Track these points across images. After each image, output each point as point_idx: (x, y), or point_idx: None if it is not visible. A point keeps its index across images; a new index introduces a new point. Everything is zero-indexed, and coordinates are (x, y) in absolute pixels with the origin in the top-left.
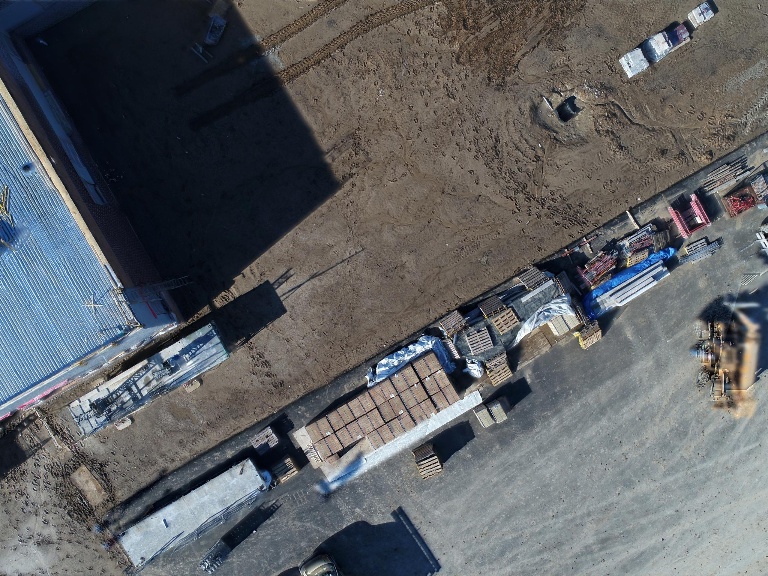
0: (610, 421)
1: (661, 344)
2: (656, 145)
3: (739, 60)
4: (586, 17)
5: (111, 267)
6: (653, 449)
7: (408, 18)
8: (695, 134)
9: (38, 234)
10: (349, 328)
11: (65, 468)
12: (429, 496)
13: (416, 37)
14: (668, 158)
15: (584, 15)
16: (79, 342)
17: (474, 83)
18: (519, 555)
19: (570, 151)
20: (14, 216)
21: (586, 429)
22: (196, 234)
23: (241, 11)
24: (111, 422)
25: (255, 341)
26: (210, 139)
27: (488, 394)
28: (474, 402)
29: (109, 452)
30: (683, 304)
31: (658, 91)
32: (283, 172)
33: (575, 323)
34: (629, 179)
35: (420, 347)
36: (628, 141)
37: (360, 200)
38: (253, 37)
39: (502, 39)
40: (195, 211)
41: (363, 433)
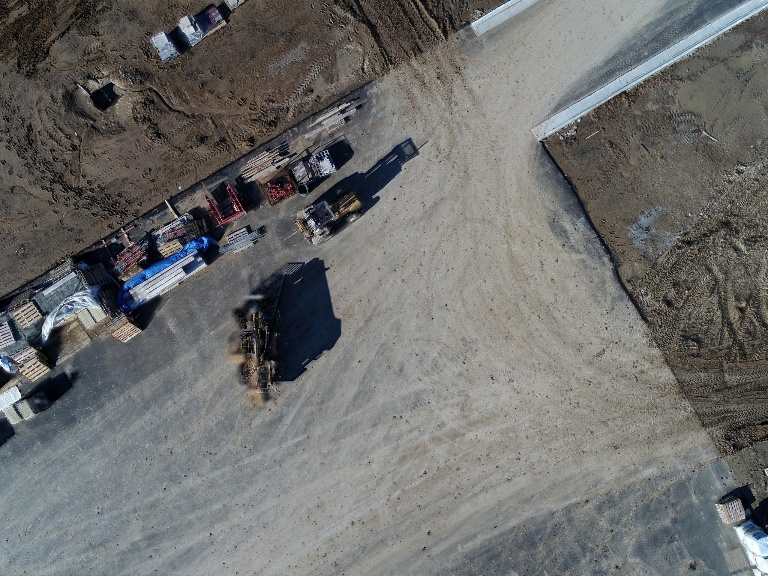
0: (154, 415)
1: (205, 336)
2: (196, 132)
3: (279, 44)
4: (118, 1)
5: None
6: (199, 443)
7: None
8: (236, 120)
9: None
10: None
11: None
12: None
13: None
14: (208, 145)
15: None
16: None
17: (3, 70)
18: (64, 553)
19: (106, 139)
20: None
21: (130, 424)
22: None
23: None
24: None
25: None
26: None
27: (27, 390)
28: (13, 398)
29: None
30: (226, 295)
31: (196, 76)
32: None
33: (101, 316)
34: (169, 167)
35: None
36: (166, 128)
37: None
38: None
39: (31, 25)
40: None
41: None
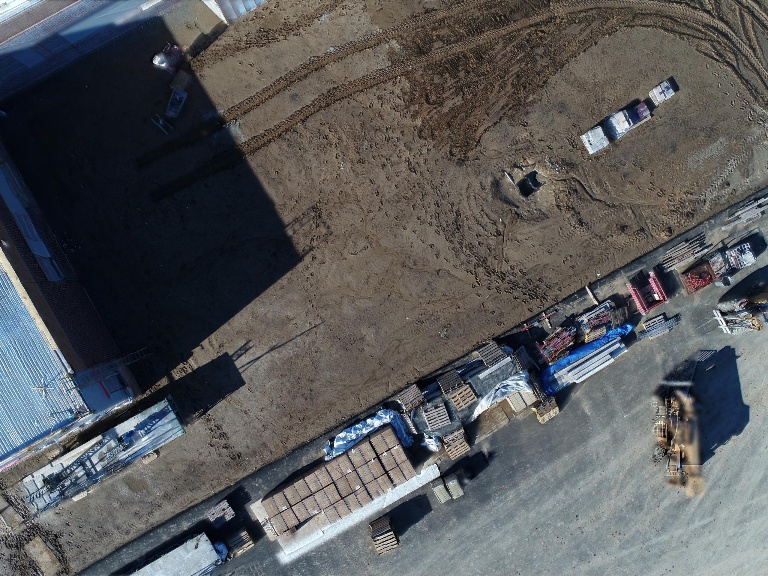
0: (567, 495)
1: (618, 419)
2: (616, 221)
3: (699, 138)
4: (548, 93)
5: (61, 352)
6: (609, 523)
7: (370, 92)
8: (655, 211)
9: None
10: (308, 400)
11: (19, 539)
12: (386, 569)
13: (378, 111)
14: (628, 234)
15: (546, 91)
16: (29, 425)
17: (436, 157)
18: None
19: (531, 226)
20: None
21: (543, 503)
22: (154, 305)
23: (202, 82)
24: (64, 500)
25: (213, 413)
26: (170, 210)
27: (446, 467)
28: (432, 475)
29: (64, 523)
30: (640, 380)
31: (619, 168)
32: (243, 244)
33: (532, 400)
34: (589, 255)
35: (378, 421)
36: (588, 217)
37: (320, 273)
38: (214, 108)
39: (464, 114)
40: (154, 282)
41: (319, 508)
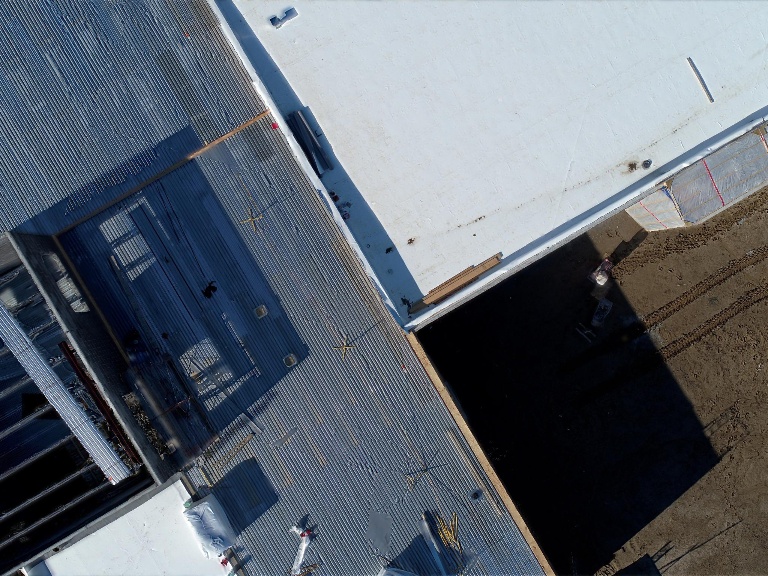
0: None
1: None
2: None
3: None
4: None
5: None
6: None
7: None
8: None
9: (485, 559)
10: None
11: None
12: None
13: None
14: None
15: None
16: None
17: None
18: None
19: None
20: (461, 542)
21: None
22: (578, 510)
23: (622, 289)
24: None
25: None
26: (591, 416)
27: None
28: None
29: None
30: None
31: None
32: (662, 446)
33: None
34: None
35: None
36: None
37: (738, 472)
38: (634, 315)
39: None
40: (576, 487)
41: None
